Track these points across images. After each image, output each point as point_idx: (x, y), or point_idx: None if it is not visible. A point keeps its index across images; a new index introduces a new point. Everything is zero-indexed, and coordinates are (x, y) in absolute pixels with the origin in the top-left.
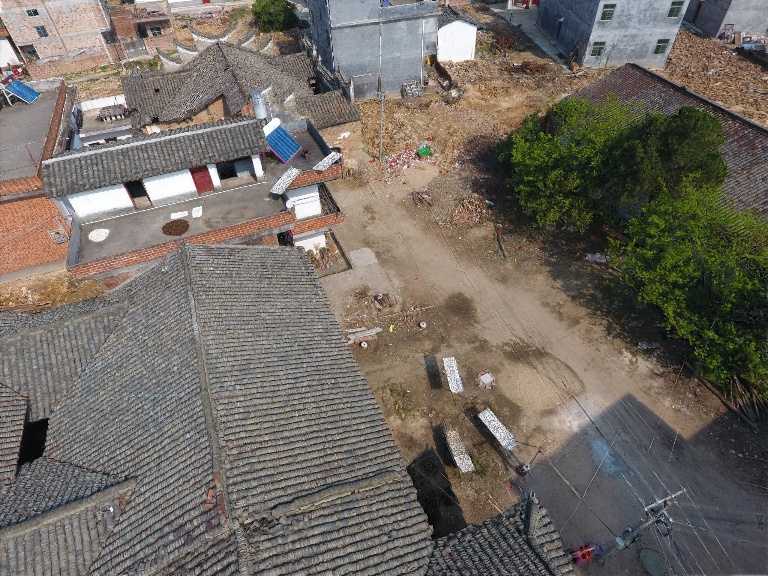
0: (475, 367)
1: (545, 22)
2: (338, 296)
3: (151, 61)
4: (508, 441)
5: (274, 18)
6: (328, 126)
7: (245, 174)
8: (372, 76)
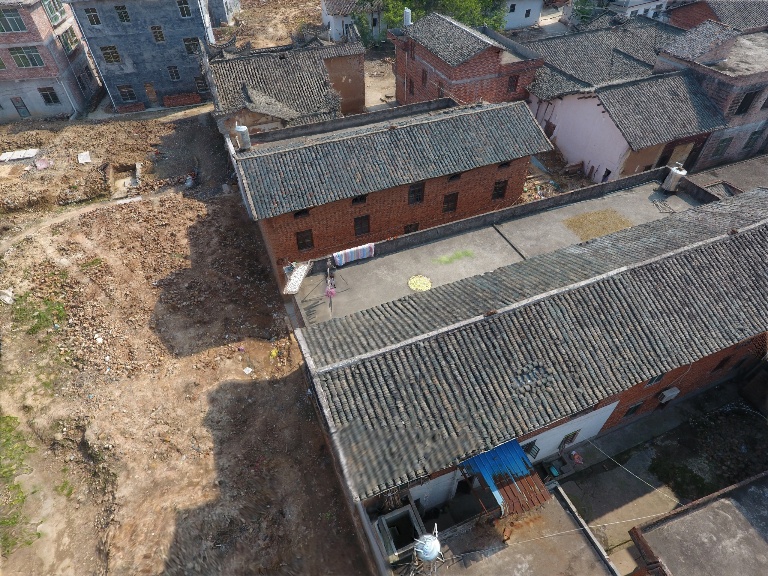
0: None
1: None
2: None
3: None
4: None
5: None
6: None
7: None
8: None
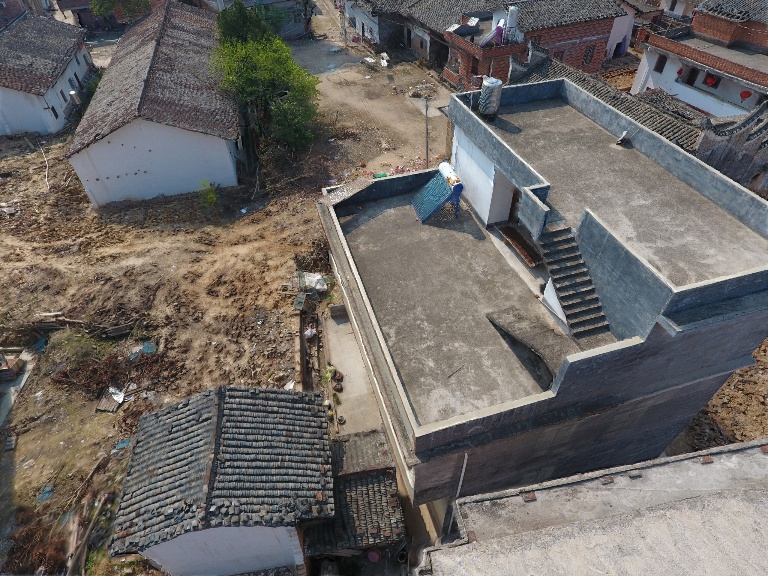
0: None
1: None
2: None
3: None
4: None
5: None
6: None
7: None
8: None
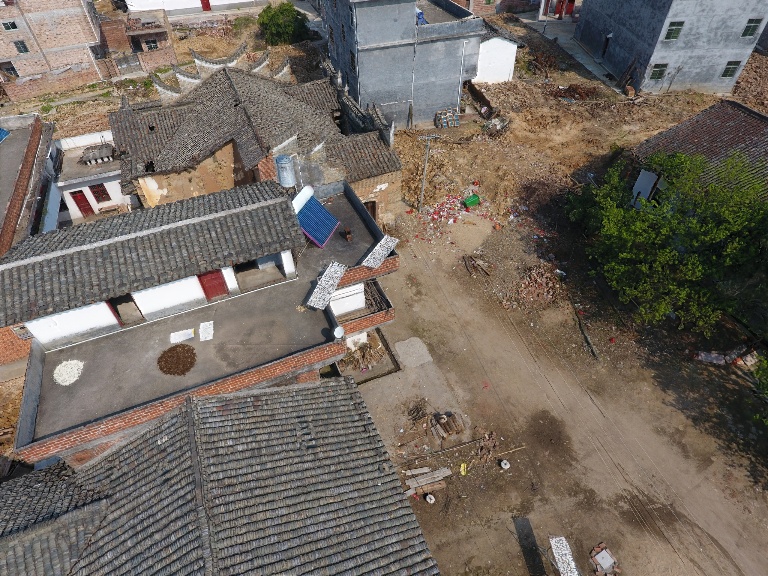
0: (585, 538)
1: (586, 36)
2: (387, 414)
3: (146, 80)
4: None
5: (283, 29)
6: (363, 178)
7: (269, 265)
8: (402, 104)
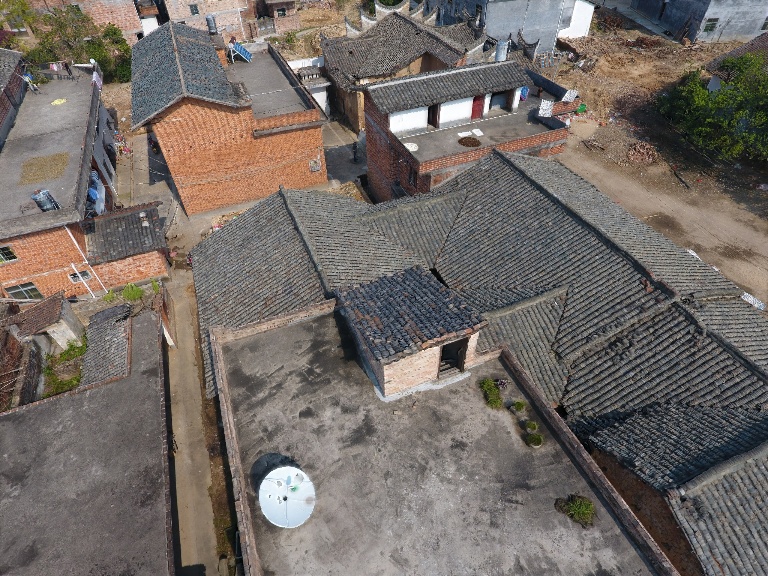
0: None
1: (643, 4)
2: None
3: (289, 37)
4: (759, 304)
5: (386, 1)
6: None
7: (497, 107)
8: None
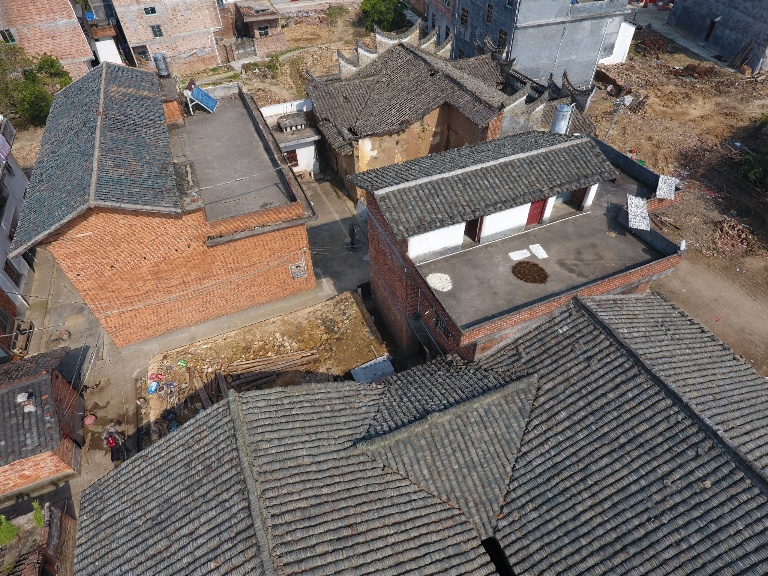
0: None
1: (684, 22)
2: None
3: (271, 63)
4: None
5: (384, 17)
6: None
7: (558, 202)
8: (543, 80)
